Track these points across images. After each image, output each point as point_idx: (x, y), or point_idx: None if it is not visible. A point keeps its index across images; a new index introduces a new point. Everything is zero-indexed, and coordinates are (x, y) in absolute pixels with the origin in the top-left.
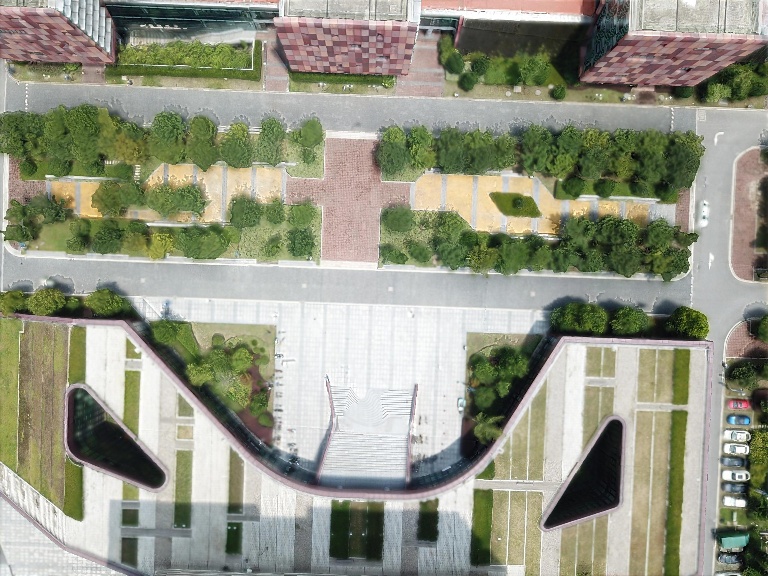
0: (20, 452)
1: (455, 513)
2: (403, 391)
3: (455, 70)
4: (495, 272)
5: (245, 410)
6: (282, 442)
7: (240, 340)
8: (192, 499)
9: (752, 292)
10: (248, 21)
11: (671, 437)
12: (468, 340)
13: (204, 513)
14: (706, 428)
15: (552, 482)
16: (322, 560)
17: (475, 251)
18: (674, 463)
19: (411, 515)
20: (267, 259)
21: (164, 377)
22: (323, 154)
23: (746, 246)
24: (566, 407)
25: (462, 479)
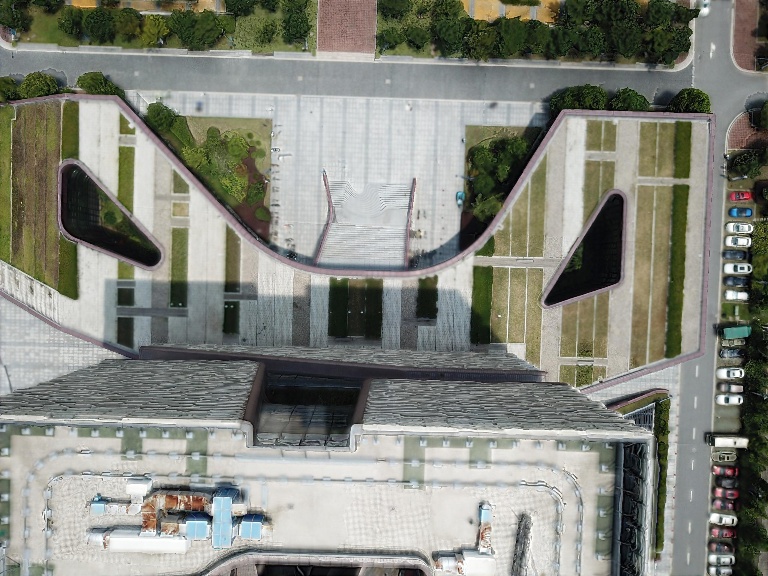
0: (14, 242)
1: (454, 291)
2: (401, 185)
3: None
4: (494, 64)
5: (241, 204)
6: (279, 238)
7: (236, 133)
8: (188, 277)
9: (754, 82)
10: None
11: (673, 212)
12: (467, 133)
13: (201, 292)
14: (708, 202)
15: (552, 258)
16: (320, 339)
17: (473, 31)
18: (676, 237)
19: (410, 293)
20: (262, 50)
21: (159, 153)
22: None
23: (748, 35)
24: (566, 182)
25: (461, 255)
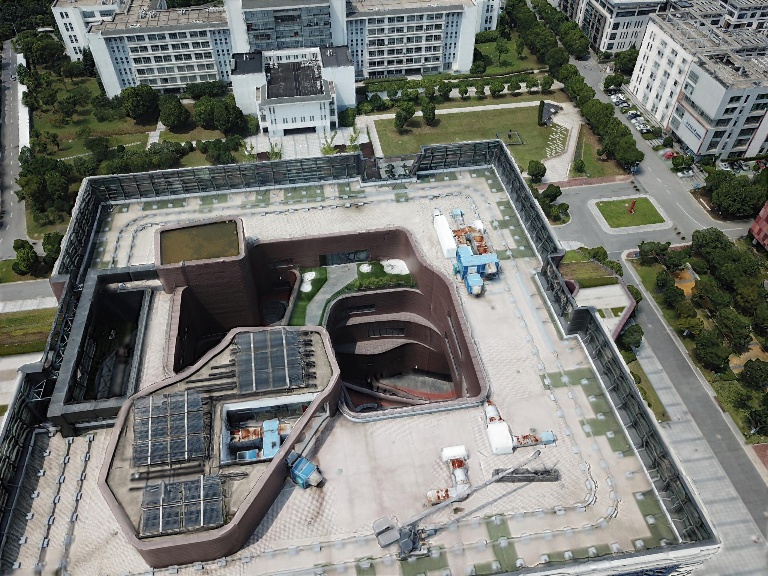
0: None
1: None
2: None
3: None
4: None
5: None
6: None
7: None
8: None
9: None
10: None
11: None
12: None
13: None
14: None
15: None
16: None
17: None
18: None
19: None
20: (723, 403)
21: None
22: None
23: None
24: None
25: None
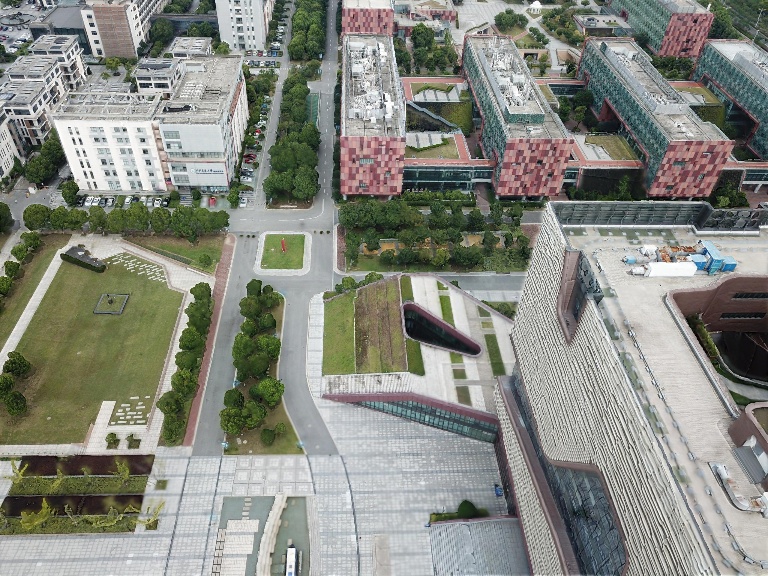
0: (358, 360)
1: None
2: None
3: (581, 196)
4: None
5: None
6: None
7: None
8: (503, 361)
9: None
10: (468, 181)
11: None
12: None
13: None
14: None
15: None
16: None
17: None
18: None
19: None
20: (503, 271)
21: (465, 298)
22: (521, 230)
23: None
24: None
25: None
